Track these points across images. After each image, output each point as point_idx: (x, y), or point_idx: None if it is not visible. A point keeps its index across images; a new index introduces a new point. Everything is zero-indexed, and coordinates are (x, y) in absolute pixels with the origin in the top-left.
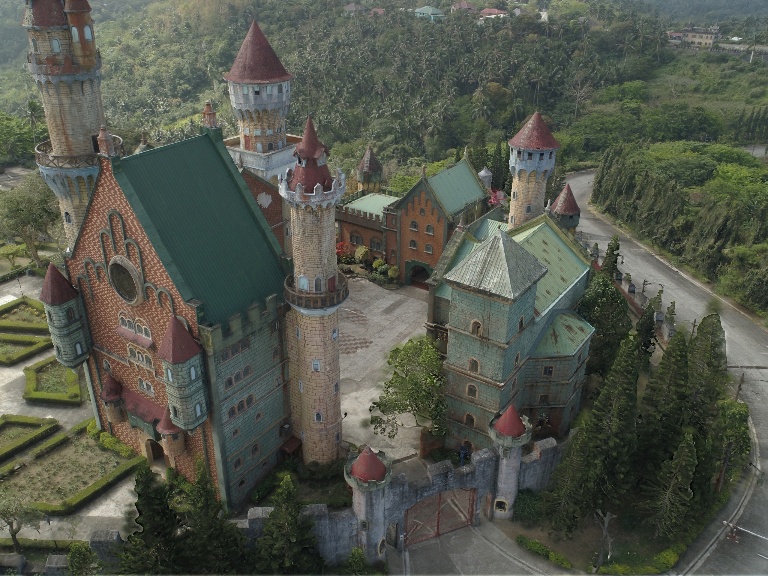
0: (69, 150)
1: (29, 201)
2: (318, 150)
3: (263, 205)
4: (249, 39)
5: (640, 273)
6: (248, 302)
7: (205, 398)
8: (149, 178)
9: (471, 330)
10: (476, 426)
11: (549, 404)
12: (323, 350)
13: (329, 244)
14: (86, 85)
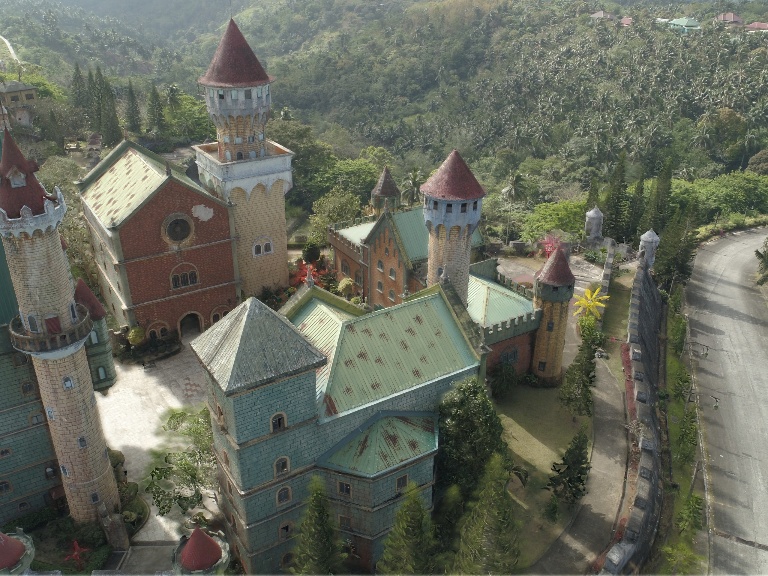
0: None
1: (46, 182)
2: (11, 168)
3: (201, 218)
4: (223, 38)
5: (744, 372)
6: None
7: None
8: None
9: (218, 415)
10: (238, 532)
11: (352, 530)
12: (54, 398)
13: (40, 279)
14: None
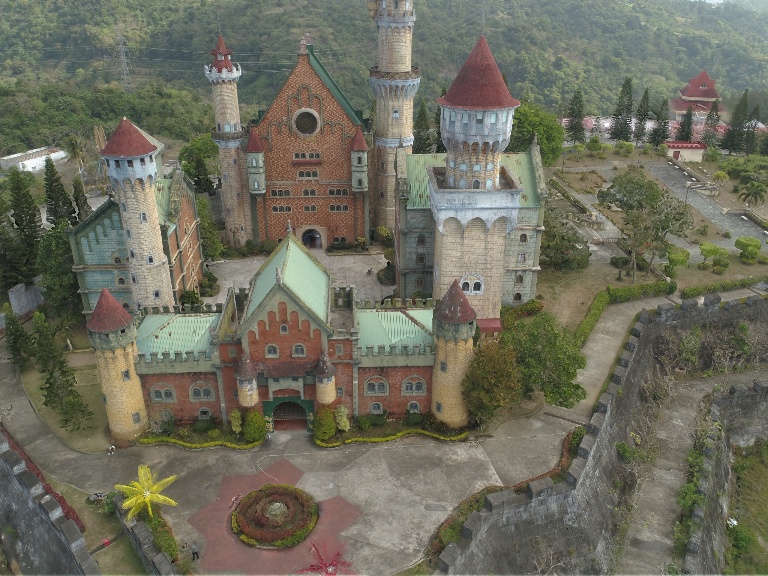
0: None
1: None
2: None
3: None
4: None
5: None
6: None
7: None
8: None
9: None
10: None
11: None
12: None
13: None
14: None
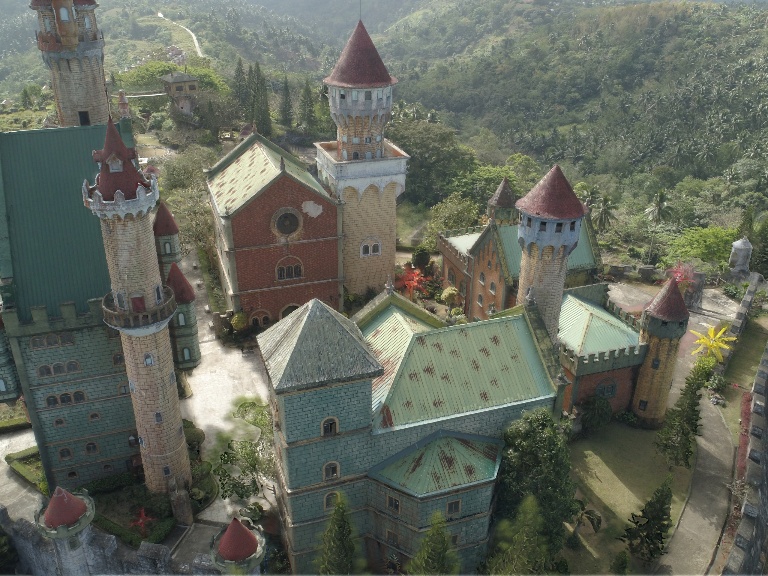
0: (62, 121)
1: (185, 168)
2: (111, 154)
3: (310, 214)
4: (350, 39)
5: None
6: (81, 298)
7: (16, 377)
8: (28, 155)
9: (275, 410)
10: (287, 528)
11: (399, 547)
12: (136, 372)
13: (129, 260)
14: (74, 63)
